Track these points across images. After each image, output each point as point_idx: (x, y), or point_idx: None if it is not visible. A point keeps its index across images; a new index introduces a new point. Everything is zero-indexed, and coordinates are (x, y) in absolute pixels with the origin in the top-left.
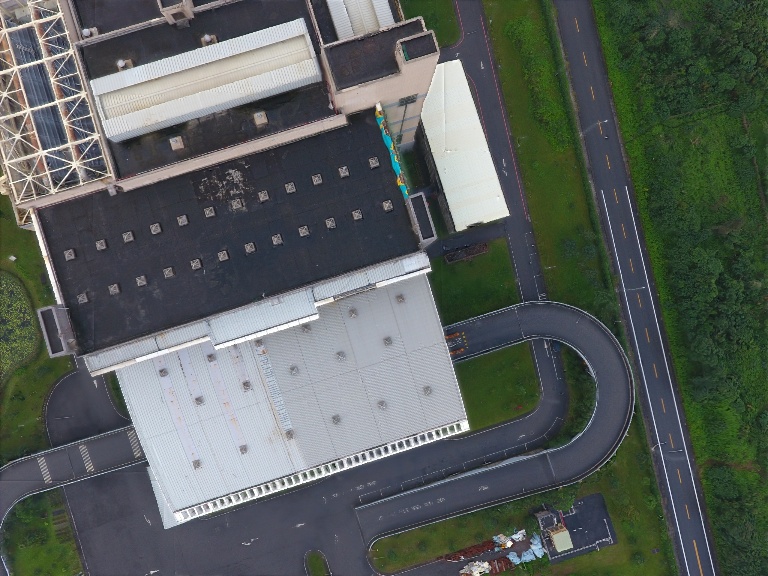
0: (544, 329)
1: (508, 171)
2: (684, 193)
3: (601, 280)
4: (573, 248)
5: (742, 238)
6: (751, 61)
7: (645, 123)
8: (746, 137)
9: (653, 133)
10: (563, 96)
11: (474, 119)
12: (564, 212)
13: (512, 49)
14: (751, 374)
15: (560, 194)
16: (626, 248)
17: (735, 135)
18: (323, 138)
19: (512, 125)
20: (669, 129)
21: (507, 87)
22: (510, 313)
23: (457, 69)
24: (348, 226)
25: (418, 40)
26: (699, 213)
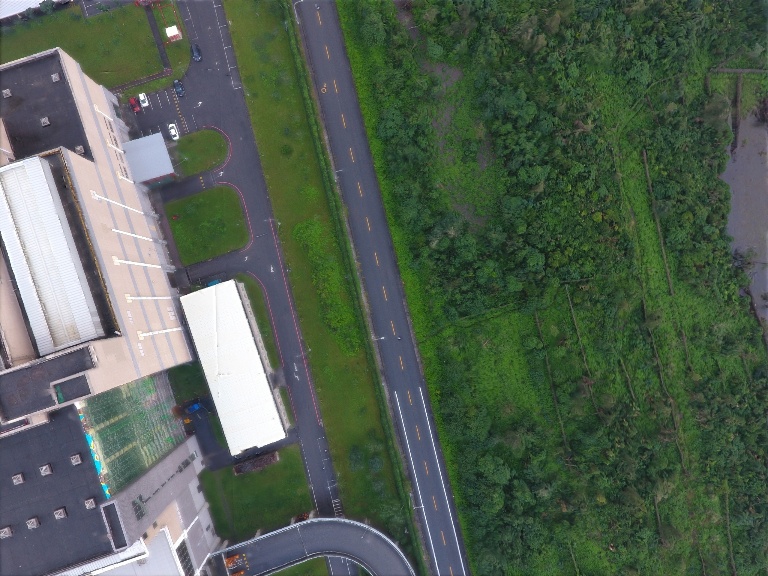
0: (328, 546)
1: (300, 376)
2: (475, 396)
3: (394, 485)
4: (358, 461)
5: (534, 440)
6: (538, 263)
7: (436, 325)
8: (534, 341)
9: (443, 336)
10: (352, 300)
11: (248, 341)
12: (356, 417)
13: (301, 252)
14: (547, 575)
15: (351, 399)
16: (421, 450)
17: (528, 334)
18: (24, 436)
19: (302, 329)
20: (461, 329)
21: (297, 290)
22: (292, 532)
23: (230, 290)
24: (51, 525)
25: (72, 381)
26: (493, 414)
